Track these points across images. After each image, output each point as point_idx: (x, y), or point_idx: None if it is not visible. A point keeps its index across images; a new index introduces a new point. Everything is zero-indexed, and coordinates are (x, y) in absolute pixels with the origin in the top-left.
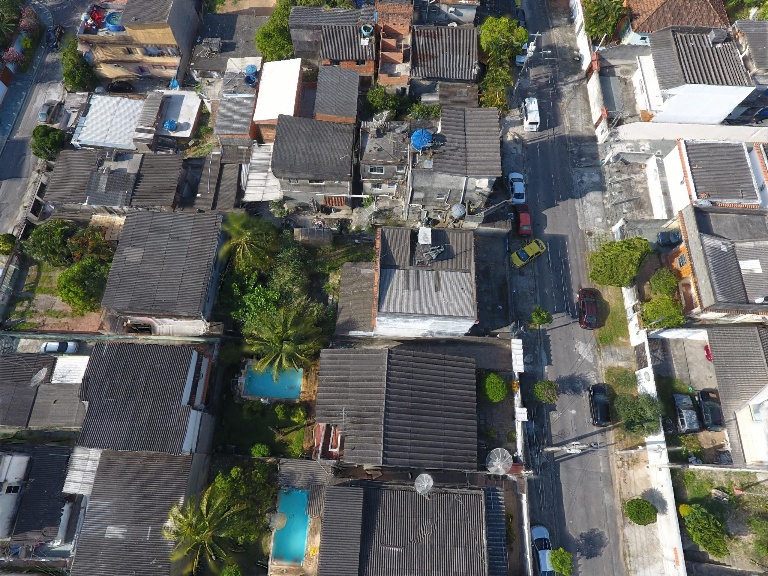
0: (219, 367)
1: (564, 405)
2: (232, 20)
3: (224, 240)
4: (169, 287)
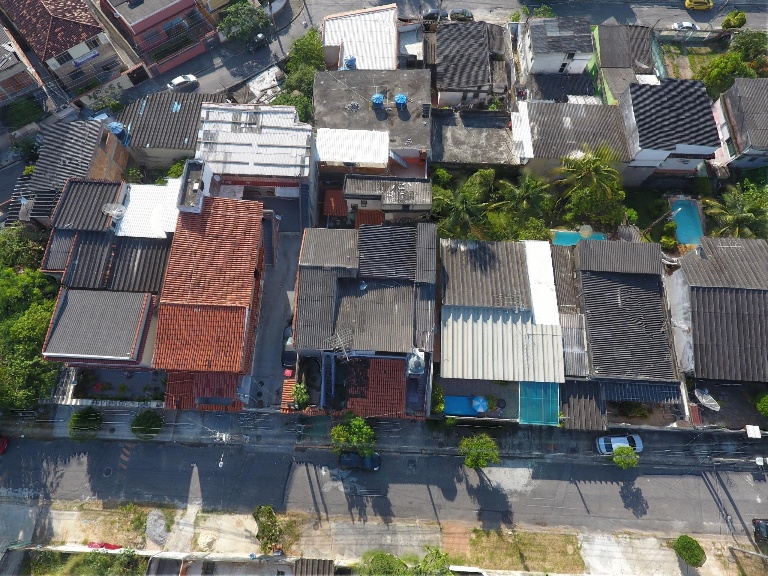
0: (686, 180)
1: (763, 490)
2: None
3: None
4: (767, 122)
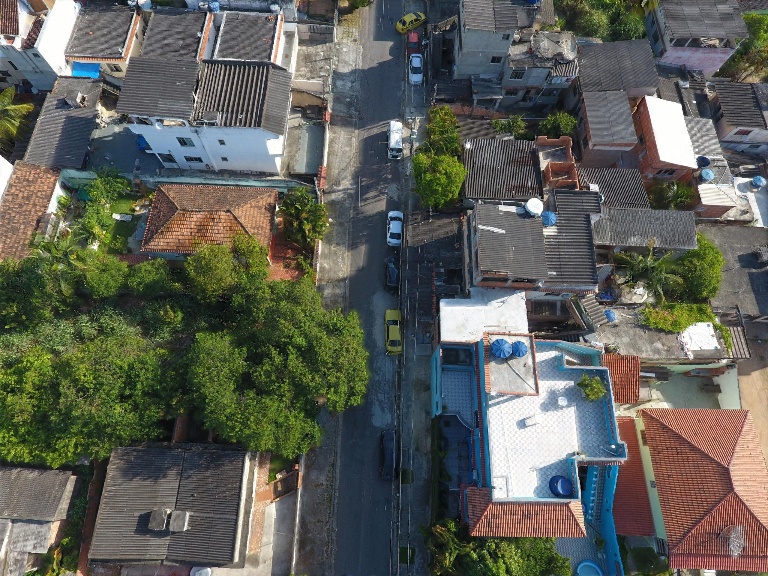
0: None
1: None
2: (764, 305)
3: (656, 54)
4: None
